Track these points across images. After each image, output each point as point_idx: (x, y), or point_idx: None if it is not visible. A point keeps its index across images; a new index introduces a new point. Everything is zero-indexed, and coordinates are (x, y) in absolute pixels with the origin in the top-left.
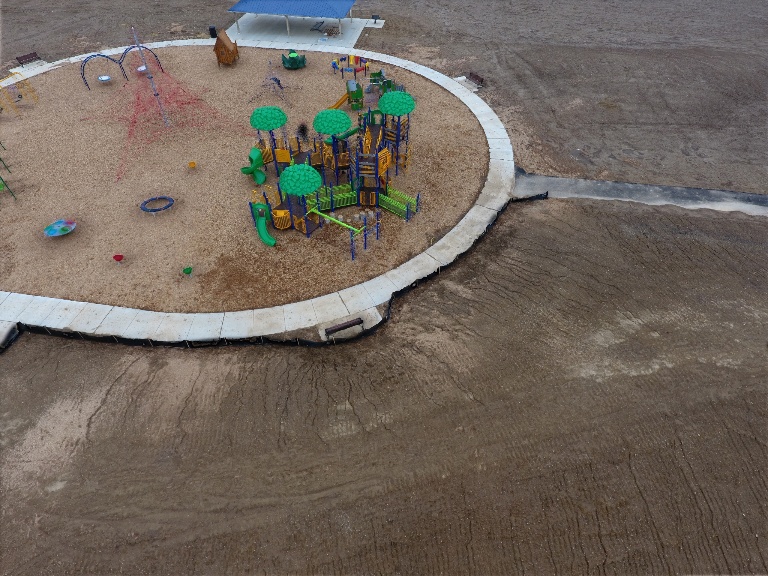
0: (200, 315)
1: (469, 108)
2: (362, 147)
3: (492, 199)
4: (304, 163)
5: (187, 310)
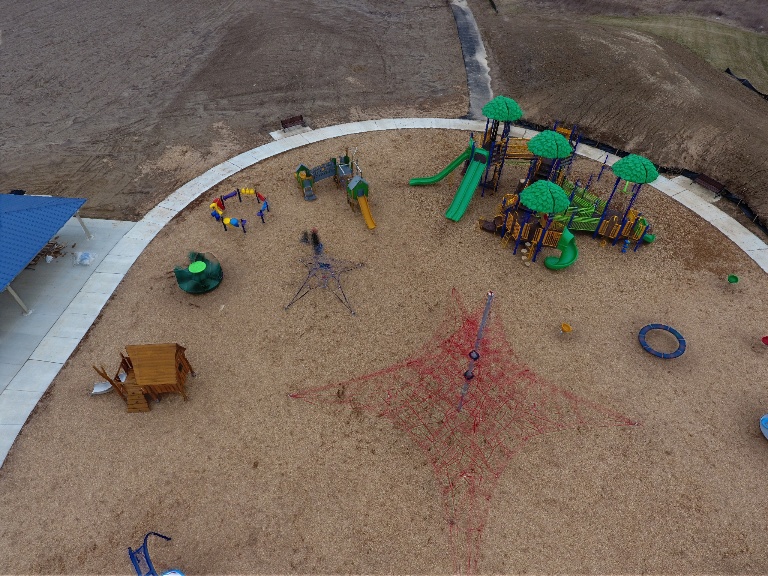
0: (761, 265)
1: (353, 133)
2: None
3: (512, 131)
4: (525, 221)
5: (765, 274)
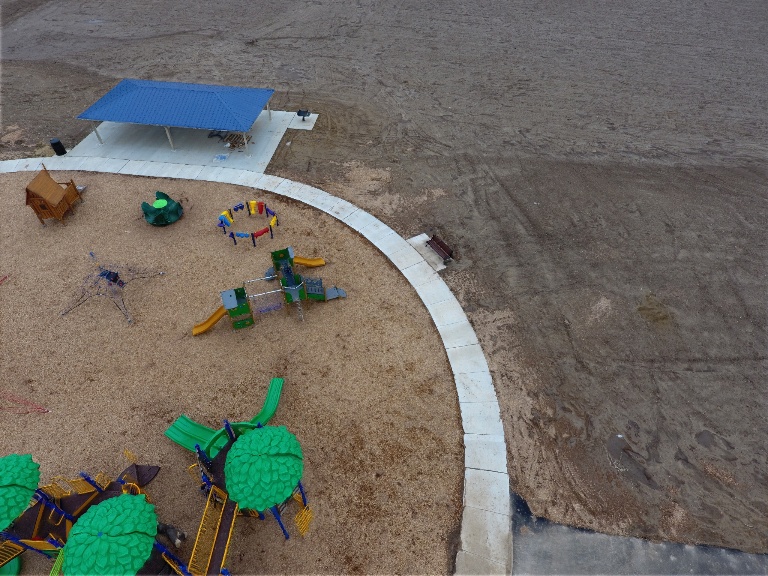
0: None
1: (430, 315)
2: (187, 572)
3: None
4: None
5: None
